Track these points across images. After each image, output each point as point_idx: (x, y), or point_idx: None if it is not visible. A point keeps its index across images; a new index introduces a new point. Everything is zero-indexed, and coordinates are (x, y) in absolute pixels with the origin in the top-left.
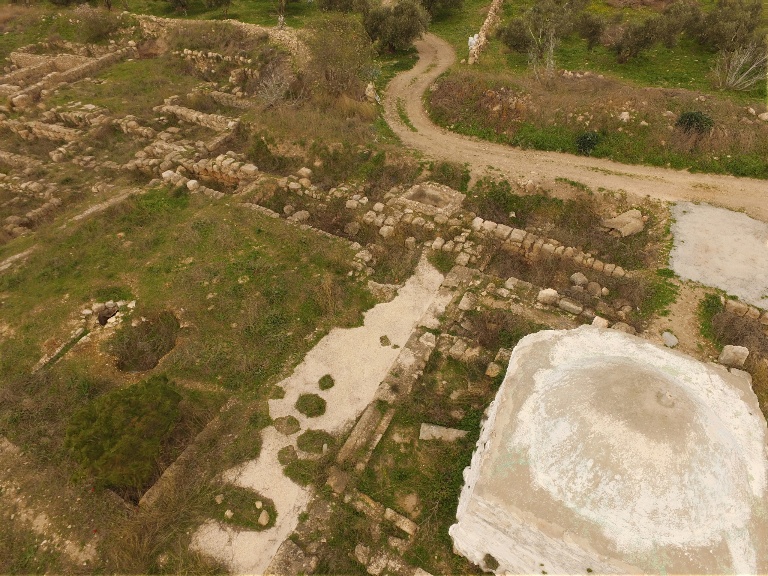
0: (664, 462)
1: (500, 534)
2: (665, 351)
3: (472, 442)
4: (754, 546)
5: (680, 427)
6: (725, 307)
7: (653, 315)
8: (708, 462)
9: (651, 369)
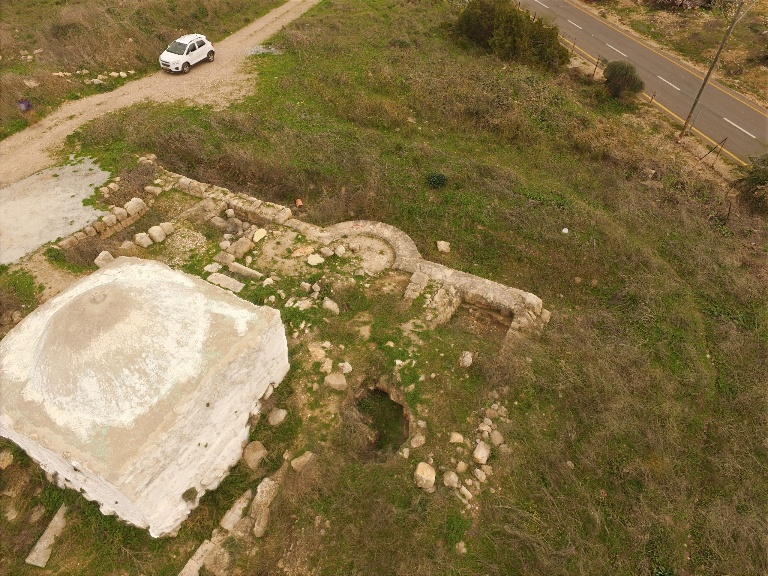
0: (144, 319)
1: (165, 474)
2: (67, 292)
3: (76, 499)
4: (219, 301)
5: (123, 298)
6: (64, 249)
7: (37, 297)
8: (157, 296)
9: (71, 300)
